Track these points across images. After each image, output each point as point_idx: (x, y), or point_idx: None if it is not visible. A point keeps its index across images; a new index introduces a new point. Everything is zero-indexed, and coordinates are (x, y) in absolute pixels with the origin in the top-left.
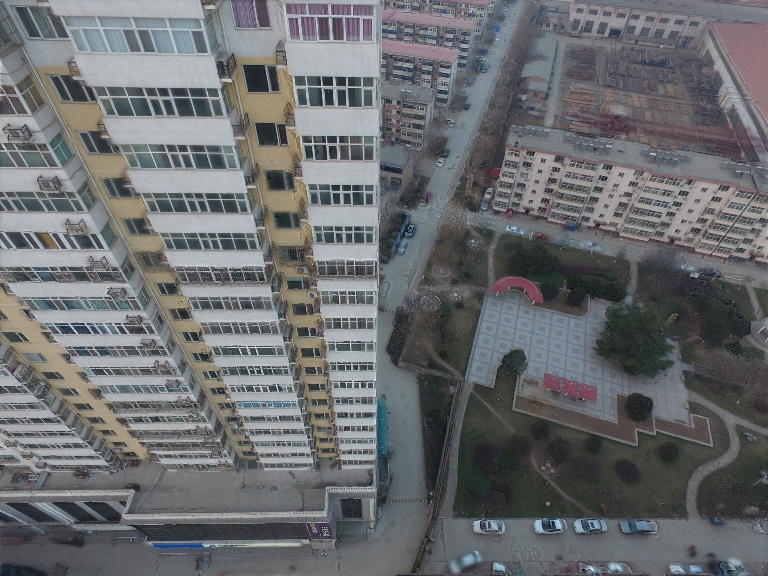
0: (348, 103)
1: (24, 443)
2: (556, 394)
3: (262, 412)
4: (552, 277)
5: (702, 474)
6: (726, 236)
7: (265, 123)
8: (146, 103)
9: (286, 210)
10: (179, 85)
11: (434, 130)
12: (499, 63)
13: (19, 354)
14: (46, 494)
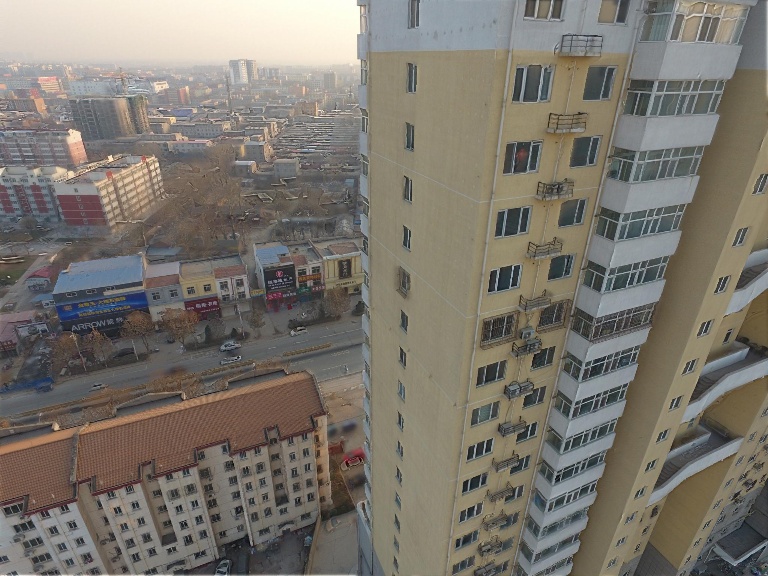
0: None
1: None
2: None
3: None
4: None
5: None
6: None
7: None
8: None
9: None
10: None
11: None
12: None
13: None
14: None
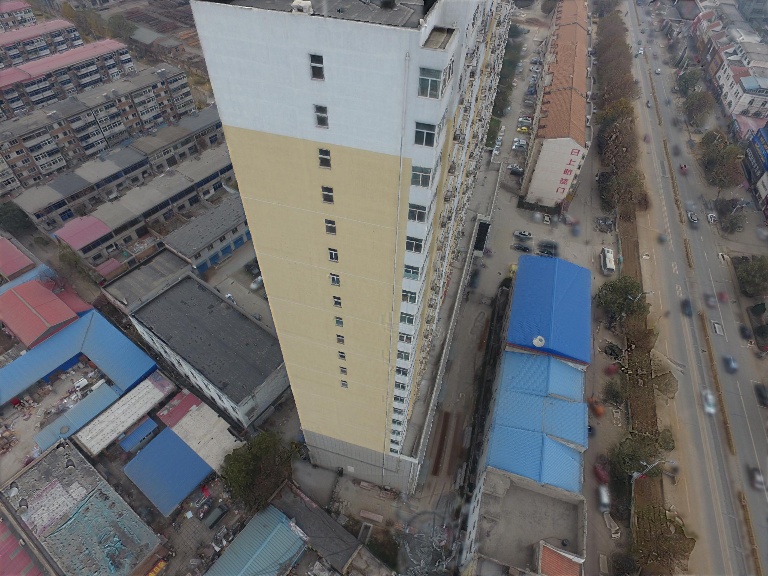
0: None
1: None
2: None
3: None
4: None
5: None
6: None
7: None
8: None
9: None
10: None
11: (198, 90)
12: None
13: None
14: None
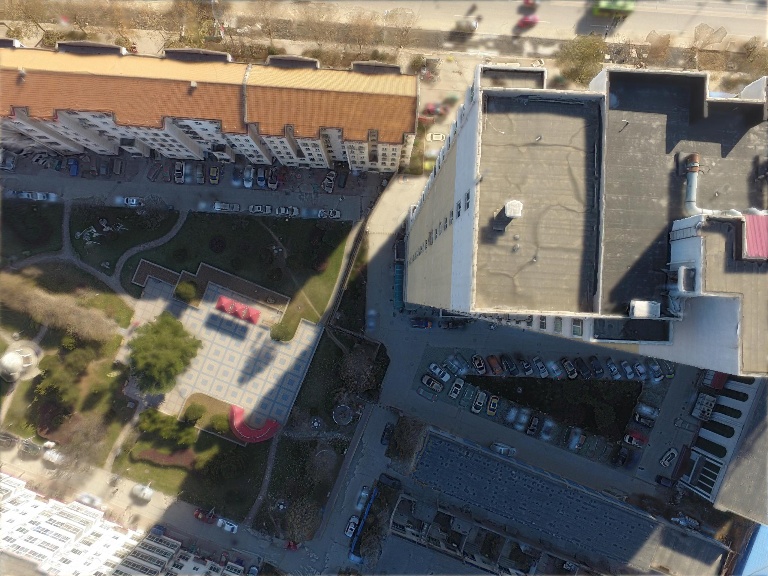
0: None
1: None
2: None
3: None
4: (208, 448)
5: (162, 240)
6: None
7: None
8: None
9: None
10: None
11: None
12: None
13: None
14: None
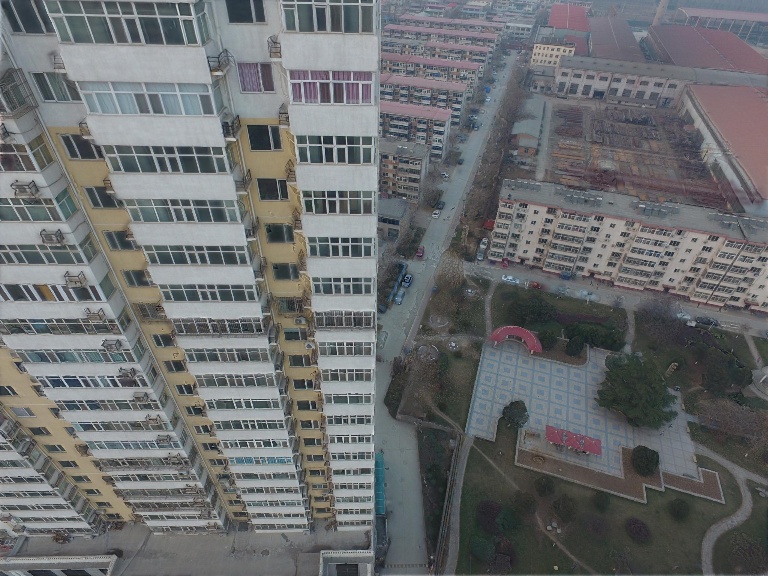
0: (347, 160)
1: (3, 504)
2: (559, 447)
3: (255, 469)
4: (550, 326)
5: (716, 533)
6: (719, 285)
7: (267, 179)
8: (152, 160)
9: (285, 262)
10: (185, 144)
11: (429, 183)
12: (490, 121)
13: (6, 408)
14: (22, 561)
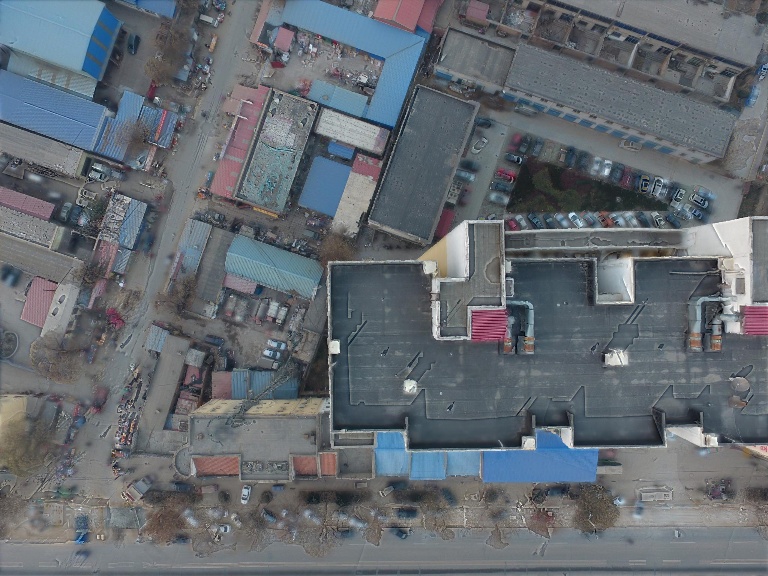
0: None
1: None
2: None
3: None
4: None
5: None
6: None
7: None
8: None
9: None
10: None
11: None
12: None
13: None
14: None
